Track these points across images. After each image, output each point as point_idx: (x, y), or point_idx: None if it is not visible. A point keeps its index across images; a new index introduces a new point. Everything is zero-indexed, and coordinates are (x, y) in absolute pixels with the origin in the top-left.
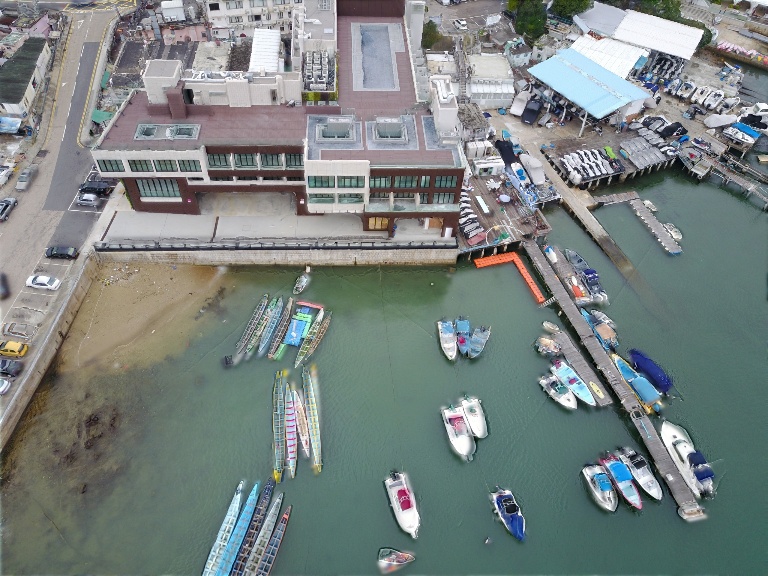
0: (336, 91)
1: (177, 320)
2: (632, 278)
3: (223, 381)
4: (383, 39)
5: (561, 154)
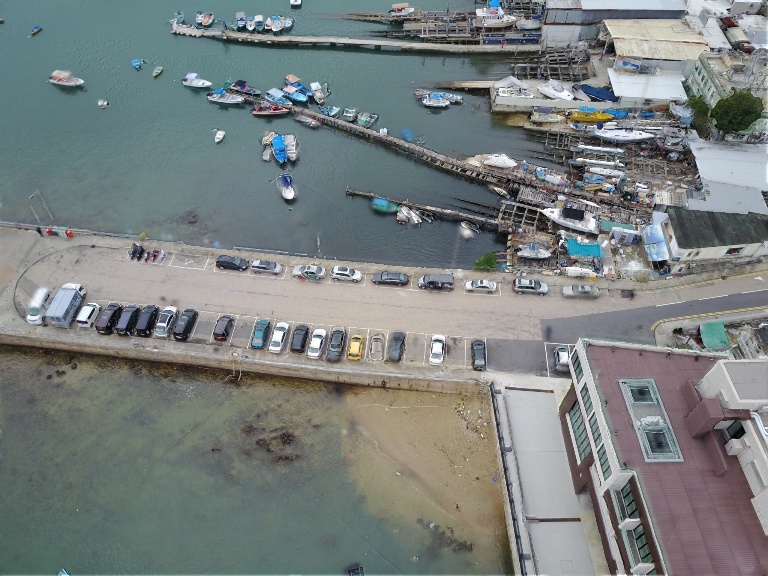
0: None
1: (416, 497)
2: None
3: (328, 570)
4: None
5: None
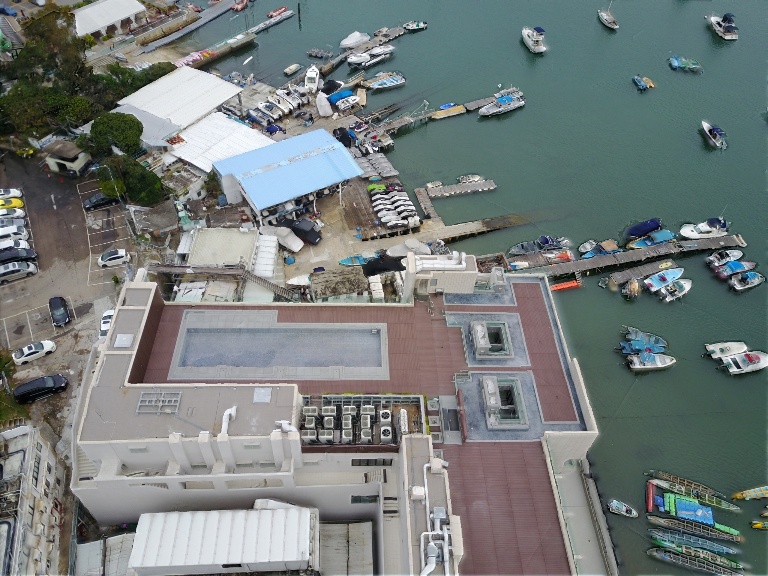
0: (420, 395)
1: None
2: (529, 219)
3: None
4: (217, 340)
5: (372, 225)
